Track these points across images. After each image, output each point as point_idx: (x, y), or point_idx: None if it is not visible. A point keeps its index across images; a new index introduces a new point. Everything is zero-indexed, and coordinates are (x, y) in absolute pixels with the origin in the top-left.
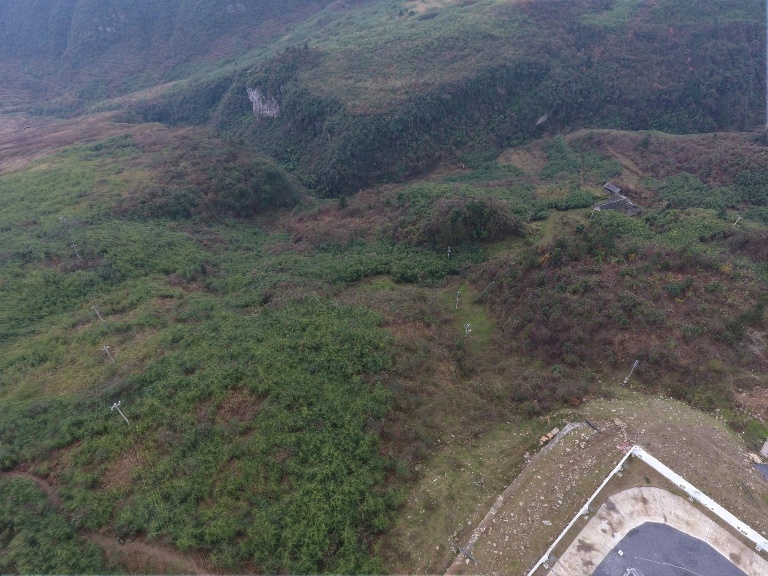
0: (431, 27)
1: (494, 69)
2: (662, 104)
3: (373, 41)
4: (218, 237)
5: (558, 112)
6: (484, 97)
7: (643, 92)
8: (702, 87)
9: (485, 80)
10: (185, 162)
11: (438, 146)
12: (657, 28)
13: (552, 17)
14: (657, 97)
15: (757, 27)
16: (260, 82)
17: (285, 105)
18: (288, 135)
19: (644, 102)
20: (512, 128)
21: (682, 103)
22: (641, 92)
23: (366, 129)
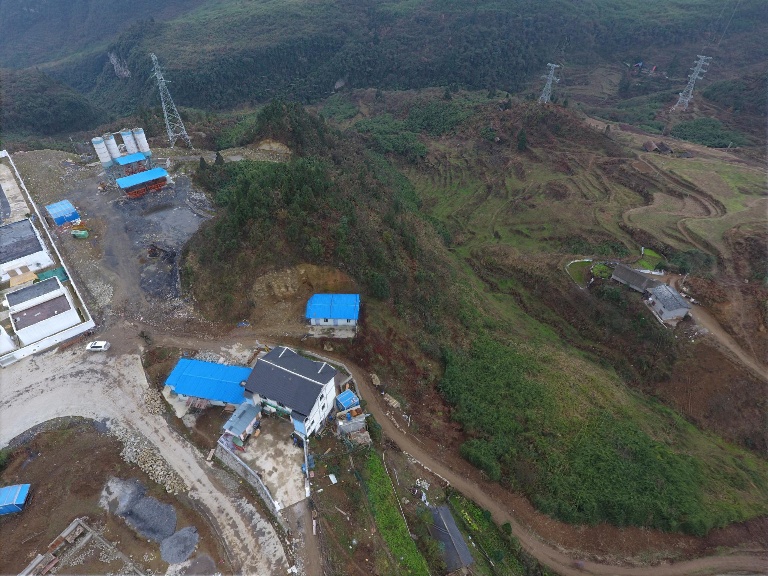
0: (255, 8)
1: (293, 41)
2: (428, 74)
3: (208, 17)
4: (2, 137)
5: (351, 79)
6: (286, 63)
7: (414, 64)
8: (456, 60)
9: (285, 49)
10: (2, 90)
11: (242, 99)
12: (433, 14)
13: (356, 4)
14: (424, 68)
15: (508, 16)
16: (115, 47)
17: (128, 65)
18: (132, 89)
19: (415, 72)
20: (311, 89)
21: (443, 73)
22: (412, 64)
23: (175, 81)
